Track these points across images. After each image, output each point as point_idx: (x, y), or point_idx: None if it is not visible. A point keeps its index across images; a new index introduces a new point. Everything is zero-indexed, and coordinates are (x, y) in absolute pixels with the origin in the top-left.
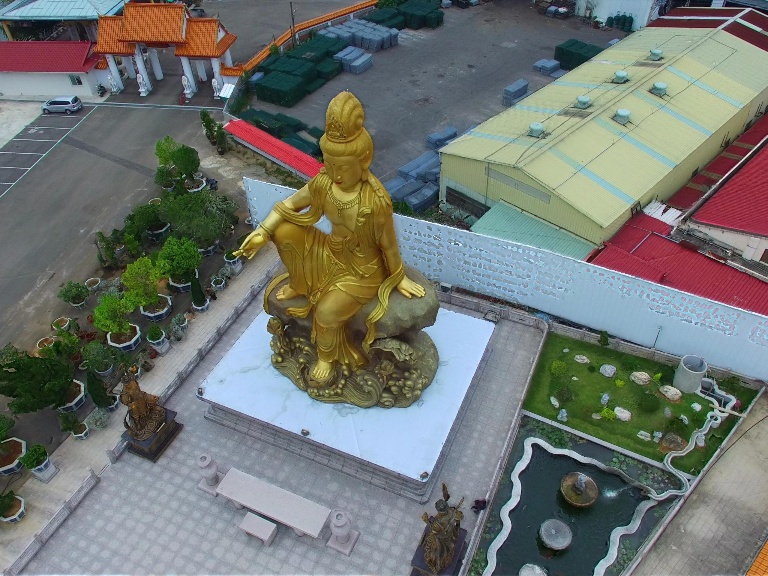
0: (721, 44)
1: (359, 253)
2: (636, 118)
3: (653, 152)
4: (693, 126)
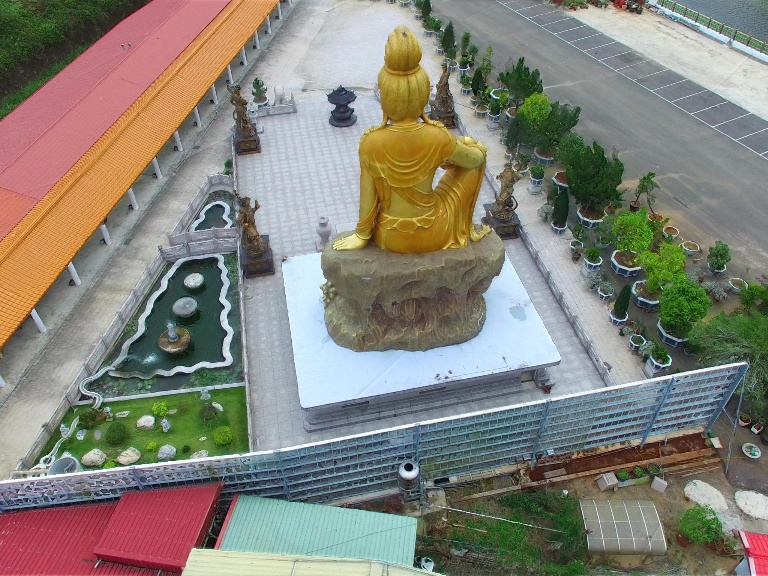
0: None
1: None
2: None
3: None
4: None
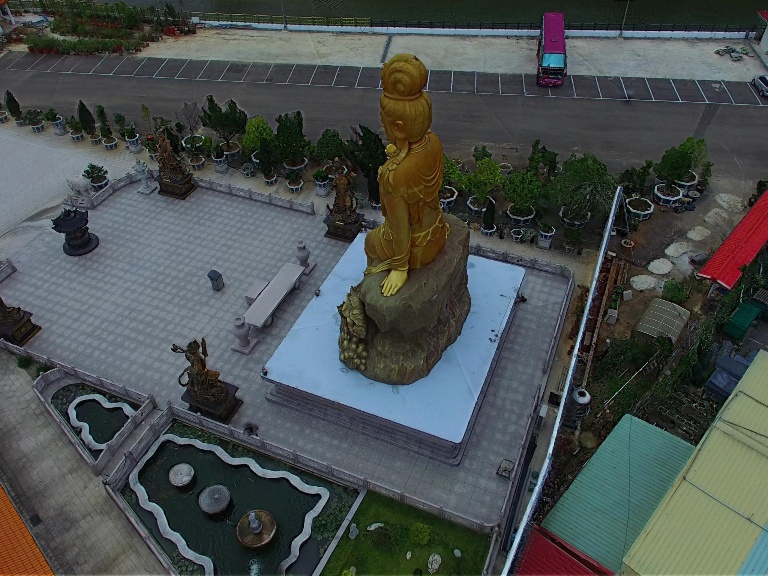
0: None
1: None
2: None
3: None
4: None
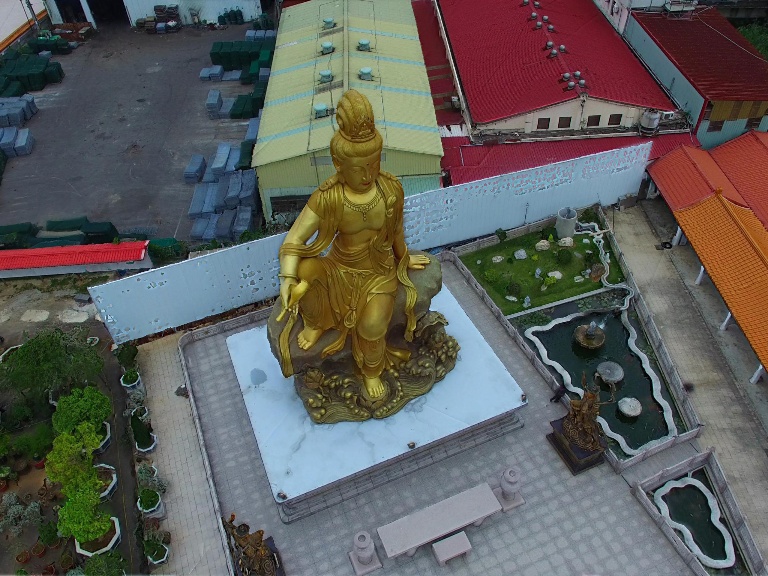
0: (359, 1)
1: (386, 248)
2: (373, 72)
3: (409, 91)
4: (409, 63)
